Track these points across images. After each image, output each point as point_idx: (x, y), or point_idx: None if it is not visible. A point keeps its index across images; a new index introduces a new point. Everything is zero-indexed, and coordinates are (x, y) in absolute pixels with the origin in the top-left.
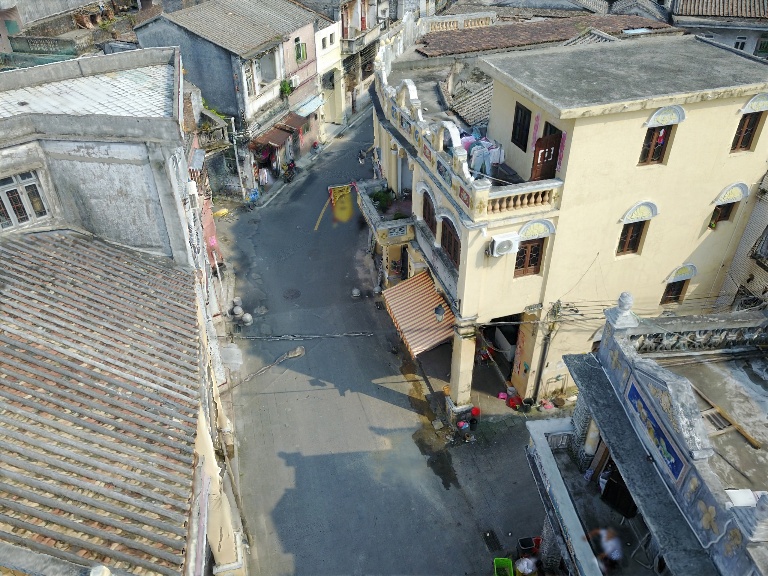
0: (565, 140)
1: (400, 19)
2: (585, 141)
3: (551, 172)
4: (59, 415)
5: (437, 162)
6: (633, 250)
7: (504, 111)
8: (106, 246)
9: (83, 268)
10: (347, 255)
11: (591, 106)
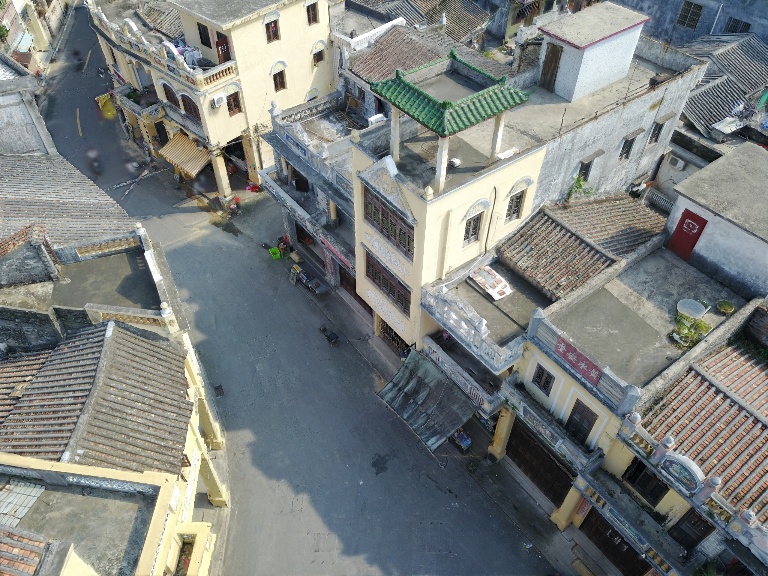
0: (229, 39)
1: None
2: (238, 38)
3: (228, 57)
4: (63, 217)
5: (167, 65)
6: (283, 87)
7: (192, 28)
8: (7, 157)
9: (8, 169)
10: (115, 145)
11: (235, 21)
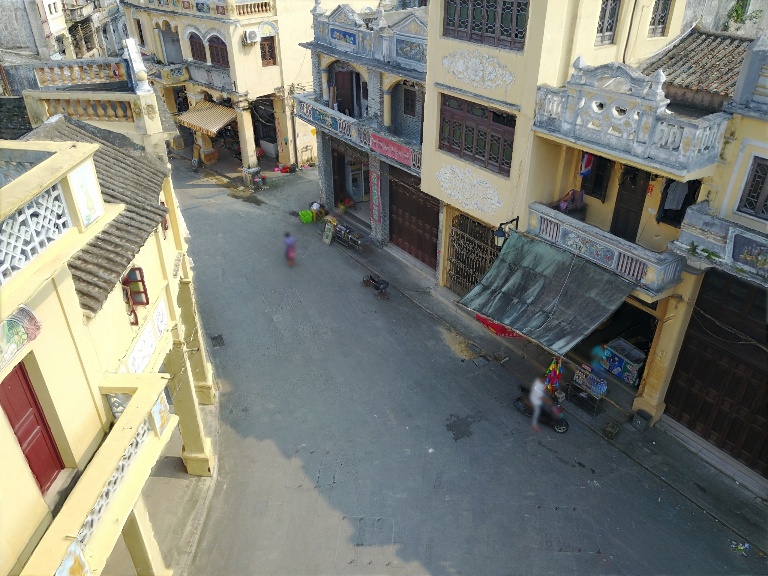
0: None
1: (104, 7)
2: None
3: None
4: None
5: (195, 4)
6: None
7: None
8: None
9: None
10: None
11: None
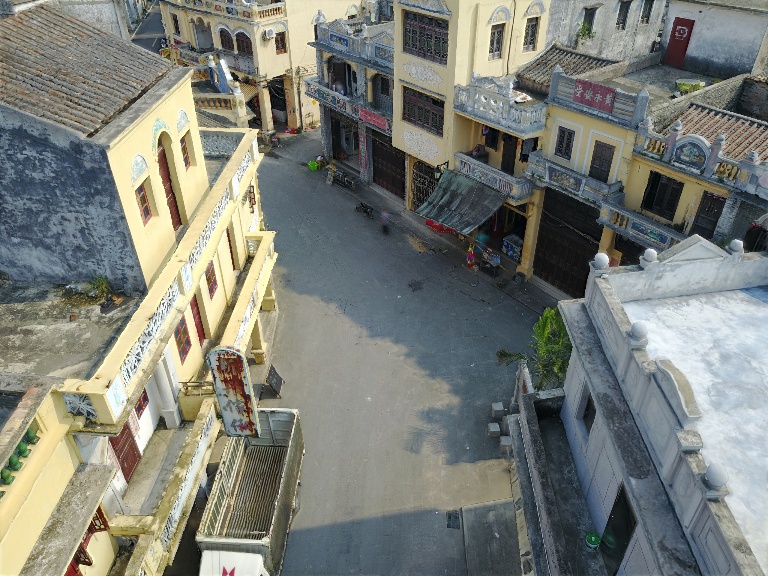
0: None
1: None
2: None
3: (279, 0)
4: None
5: (226, 8)
6: None
7: None
8: None
9: None
10: None
11: None
